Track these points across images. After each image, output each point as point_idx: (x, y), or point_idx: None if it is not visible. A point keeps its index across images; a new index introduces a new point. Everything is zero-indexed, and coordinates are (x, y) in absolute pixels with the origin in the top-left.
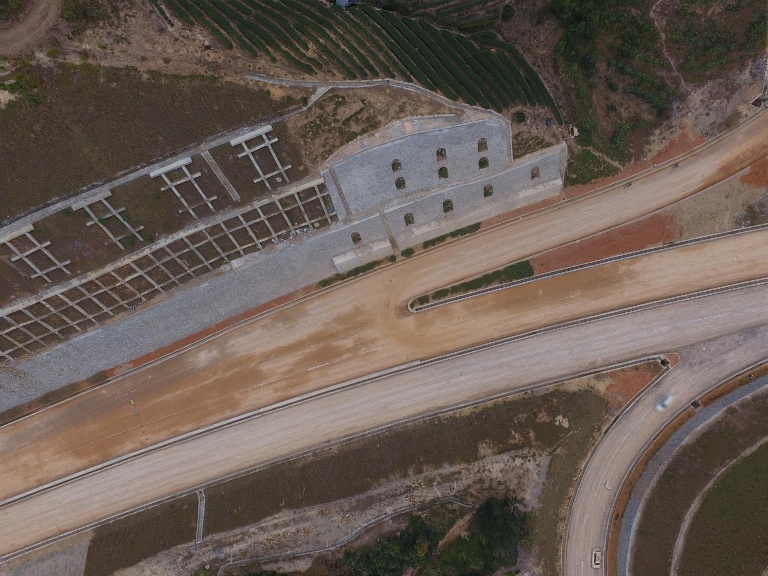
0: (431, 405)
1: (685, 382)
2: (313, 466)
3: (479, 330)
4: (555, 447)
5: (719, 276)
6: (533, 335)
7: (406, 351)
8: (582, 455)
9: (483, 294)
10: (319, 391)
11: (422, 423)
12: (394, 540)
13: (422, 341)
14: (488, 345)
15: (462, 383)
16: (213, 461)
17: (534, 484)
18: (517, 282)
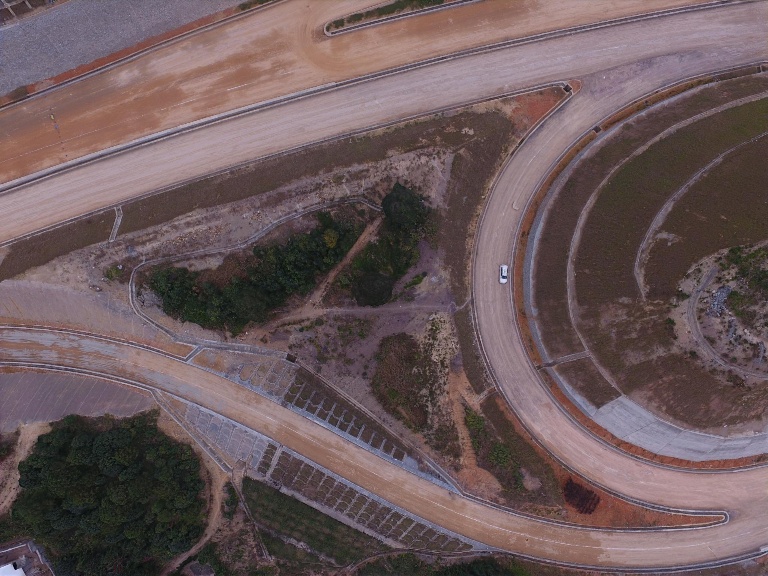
0: (346, 127)
1: (587, 109)
2: (230, 181)
3: (392, 55)
4: (459, 147)
5: (617, 10)
6: (443, 60)
7: (322, 74)
8: (490, 174)
9: (396, 20)
10: (237, 109)
11: (337, 143)
12: (303, 233)
13: (338, 65)
14: (400, 69)
15: (376, 106)
16: (132, 180)
17: (439, 182)
18: (428, 9)
